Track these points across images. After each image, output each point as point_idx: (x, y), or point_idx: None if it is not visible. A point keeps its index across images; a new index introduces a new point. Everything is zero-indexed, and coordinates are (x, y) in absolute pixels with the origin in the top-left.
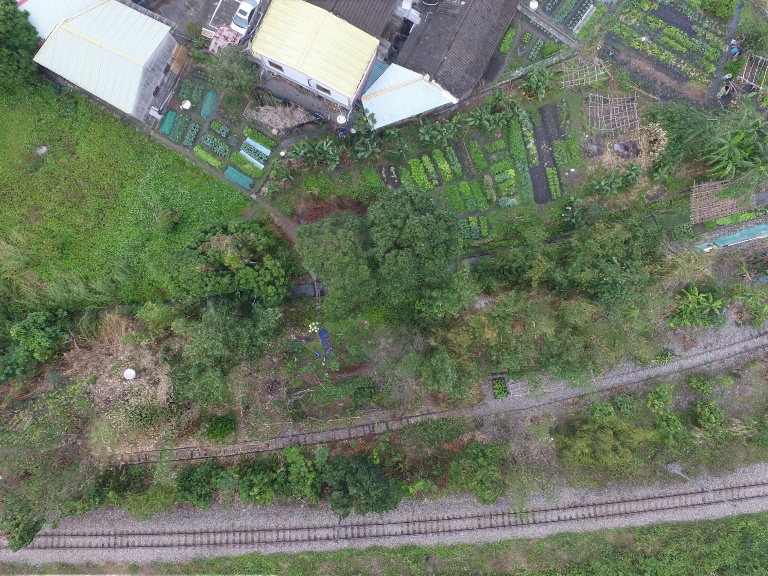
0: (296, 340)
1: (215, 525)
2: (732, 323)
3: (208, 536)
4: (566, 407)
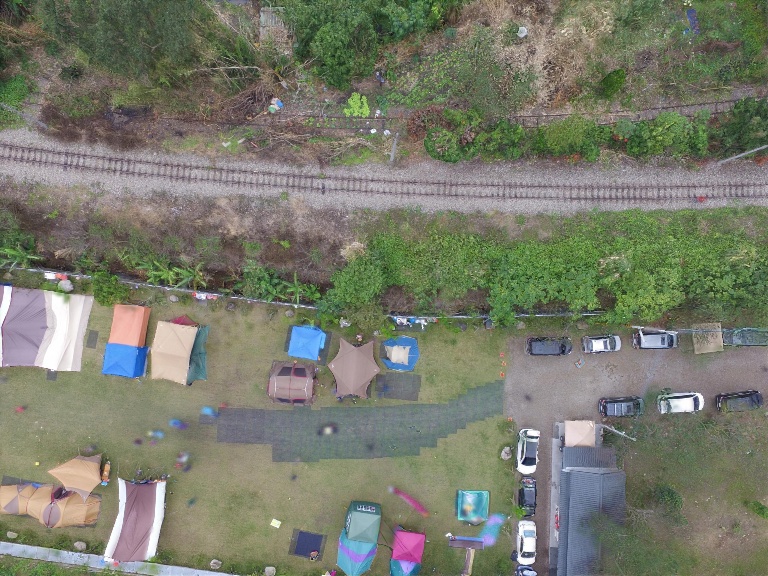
0: (667, 16)
1: (598, 181)
2: None
3: (592, 191)
4: None
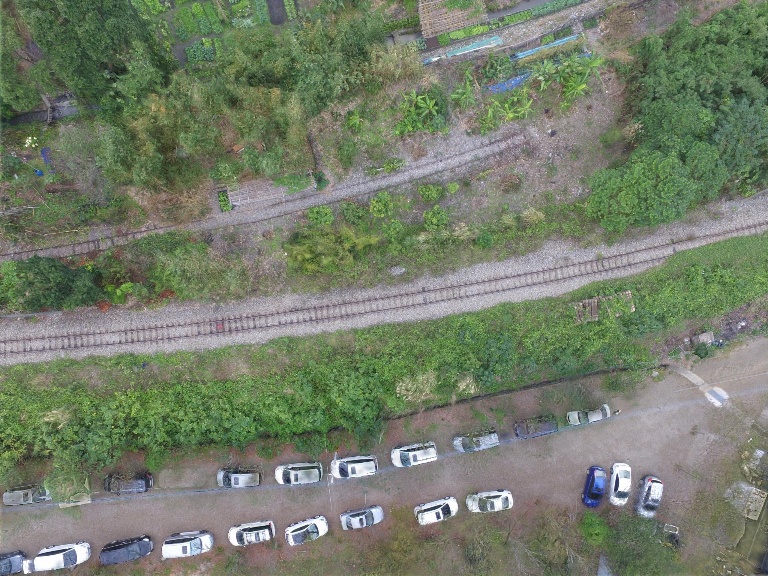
0: (16, 157)
1: None
2: (463, 133)
3: None
4: (297, 220)
